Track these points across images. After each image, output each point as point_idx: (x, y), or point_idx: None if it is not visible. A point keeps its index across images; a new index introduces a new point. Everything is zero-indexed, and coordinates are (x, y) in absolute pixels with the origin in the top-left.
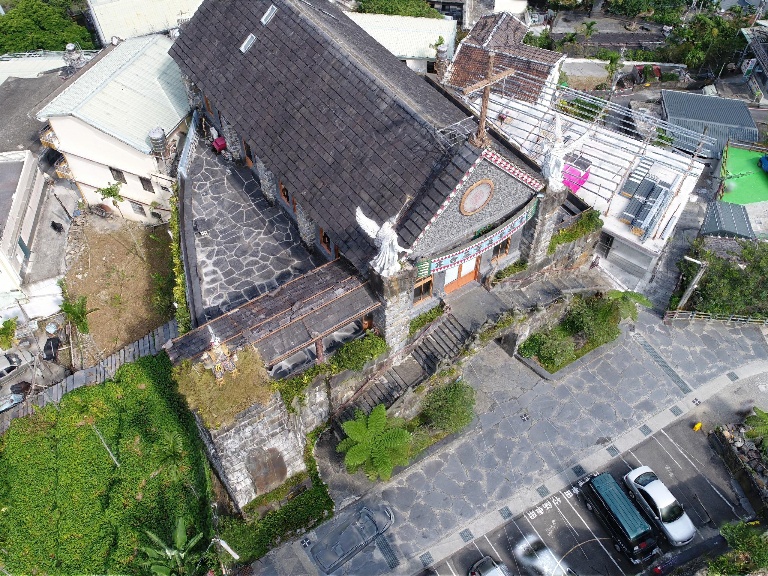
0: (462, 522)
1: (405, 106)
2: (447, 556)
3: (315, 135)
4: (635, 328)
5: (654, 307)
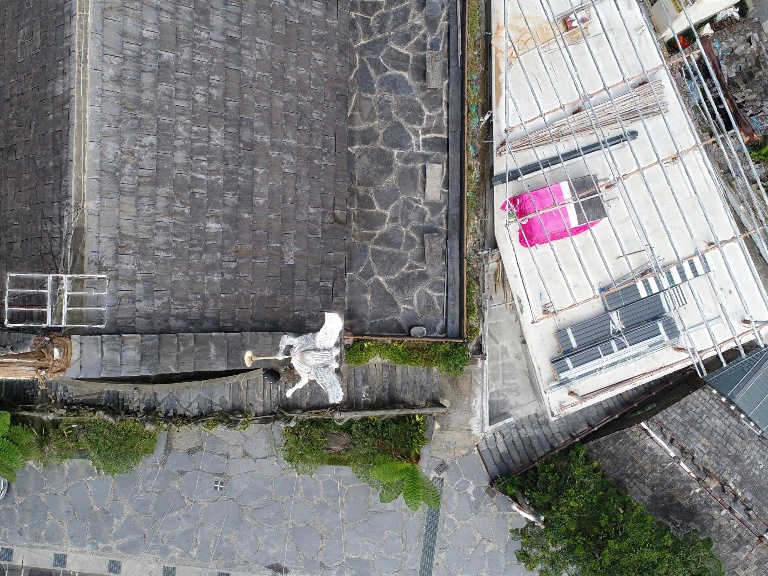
0: (66, 545)
1: (70, 127)
2: (27, 566)
3: (1, 23)
4: (445, 470)
5: (508, 451)
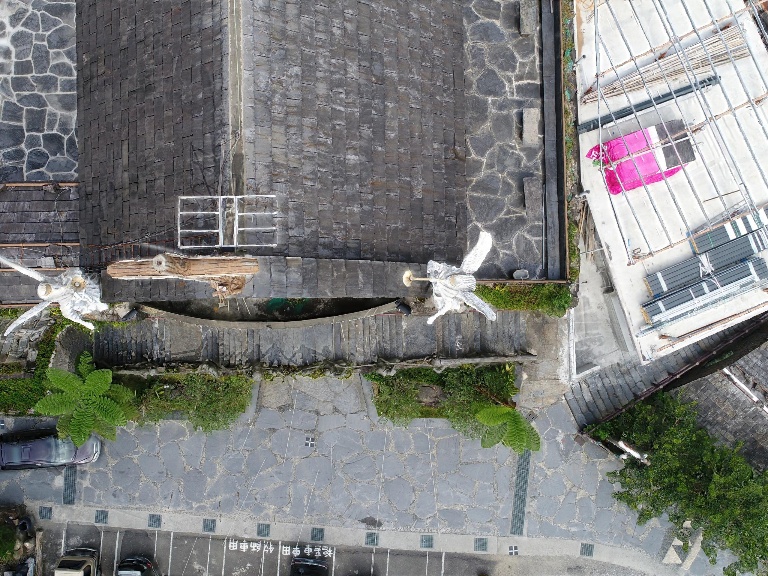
0: (160, 505)
1: (224, 57)
2: (122, 527)
3: None
4: (534, 420)
5: (594, 400)
